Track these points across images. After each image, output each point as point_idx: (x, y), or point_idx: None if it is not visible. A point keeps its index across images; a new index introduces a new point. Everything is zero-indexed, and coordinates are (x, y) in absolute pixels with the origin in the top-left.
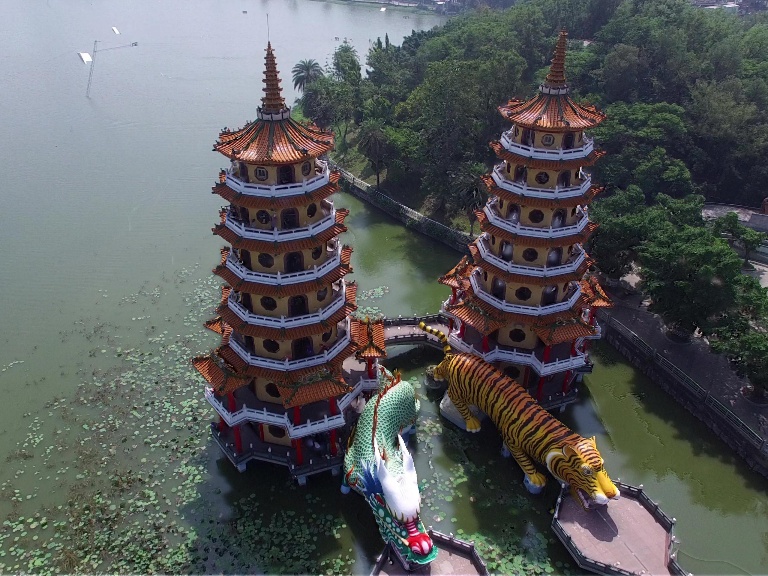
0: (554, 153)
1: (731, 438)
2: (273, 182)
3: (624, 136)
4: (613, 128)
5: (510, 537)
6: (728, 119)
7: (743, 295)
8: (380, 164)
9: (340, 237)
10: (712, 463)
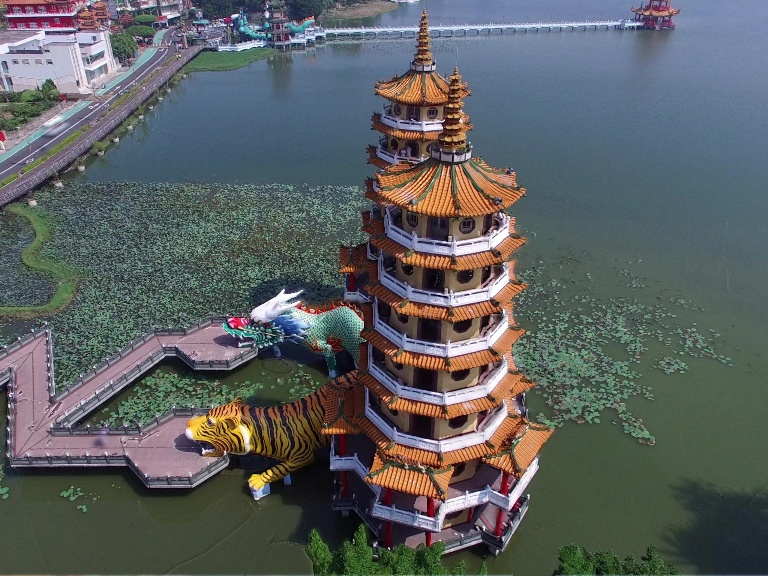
0: None
1: None
2: None
3: None
4: None
5: None
6: None
7: None
8: None
9: None
10: None
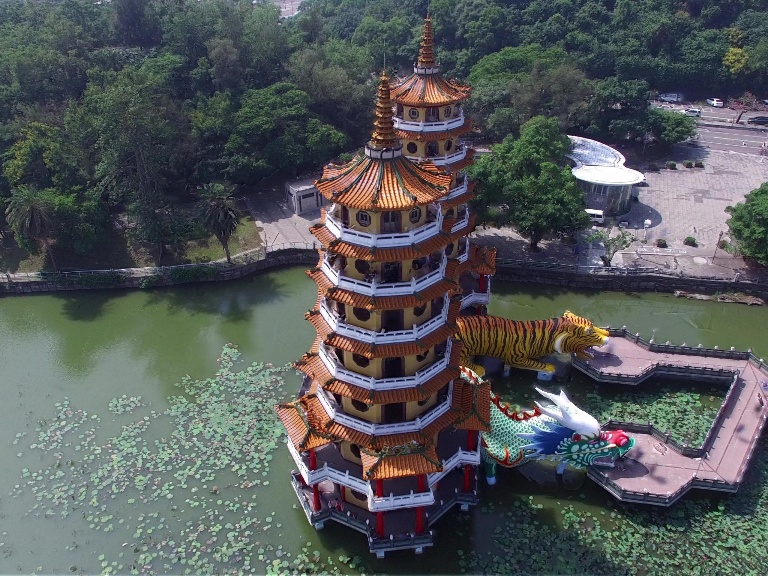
0: (458, 120)
1: (555, 278)
2: (425, 219)
3: (278, 119)
4: (271, 114)
5: (585, 409)
6: (336, 82)
7: (515, 186)
8: (36, 242)
9: (28, 353)
10: (562, 298)
